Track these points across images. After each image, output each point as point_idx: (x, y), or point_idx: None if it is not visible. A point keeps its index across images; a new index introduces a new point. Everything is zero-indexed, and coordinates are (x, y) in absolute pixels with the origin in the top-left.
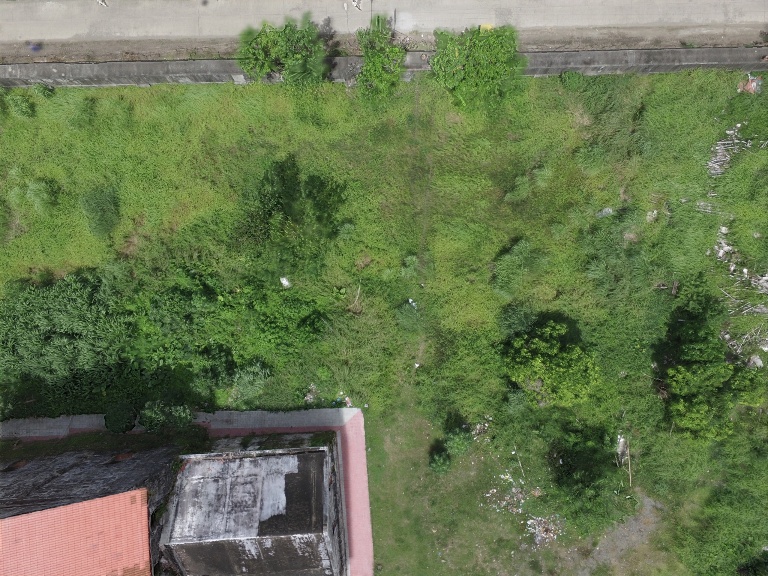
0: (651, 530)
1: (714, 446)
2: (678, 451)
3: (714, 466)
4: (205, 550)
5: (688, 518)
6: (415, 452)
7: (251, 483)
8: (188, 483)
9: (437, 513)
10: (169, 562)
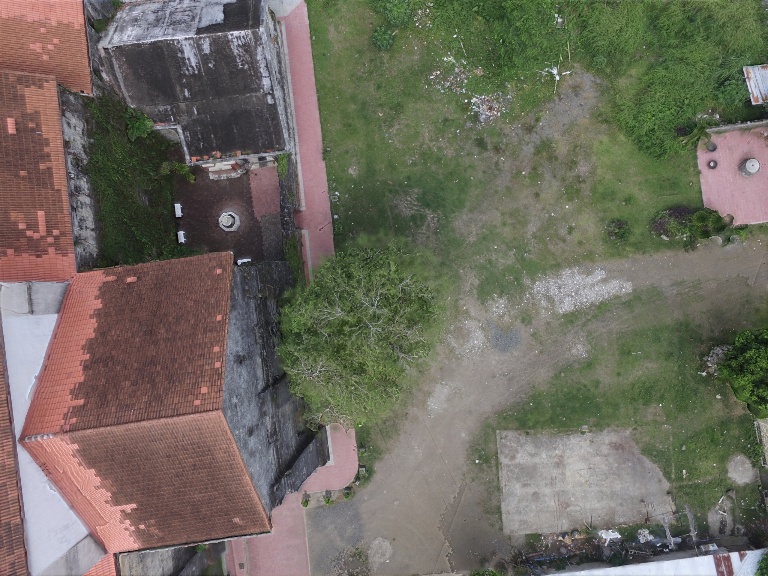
0: (591, 104)
1: (649, 24)
2: (613, 19)
3: (649, 37)
4: (145, 59)
5: (626, 88)
6: (359, 40)
7: (190, 10)
8: (128, 15)
9: (383, 97)
10: (111, 81)
